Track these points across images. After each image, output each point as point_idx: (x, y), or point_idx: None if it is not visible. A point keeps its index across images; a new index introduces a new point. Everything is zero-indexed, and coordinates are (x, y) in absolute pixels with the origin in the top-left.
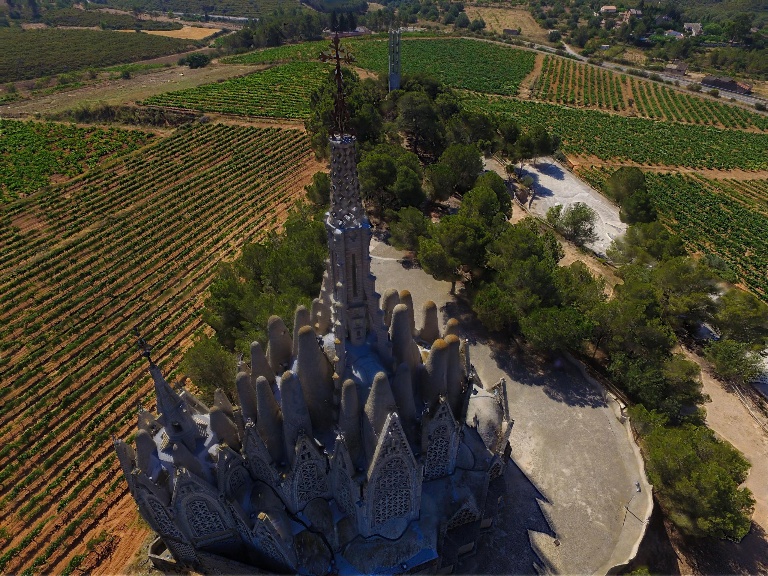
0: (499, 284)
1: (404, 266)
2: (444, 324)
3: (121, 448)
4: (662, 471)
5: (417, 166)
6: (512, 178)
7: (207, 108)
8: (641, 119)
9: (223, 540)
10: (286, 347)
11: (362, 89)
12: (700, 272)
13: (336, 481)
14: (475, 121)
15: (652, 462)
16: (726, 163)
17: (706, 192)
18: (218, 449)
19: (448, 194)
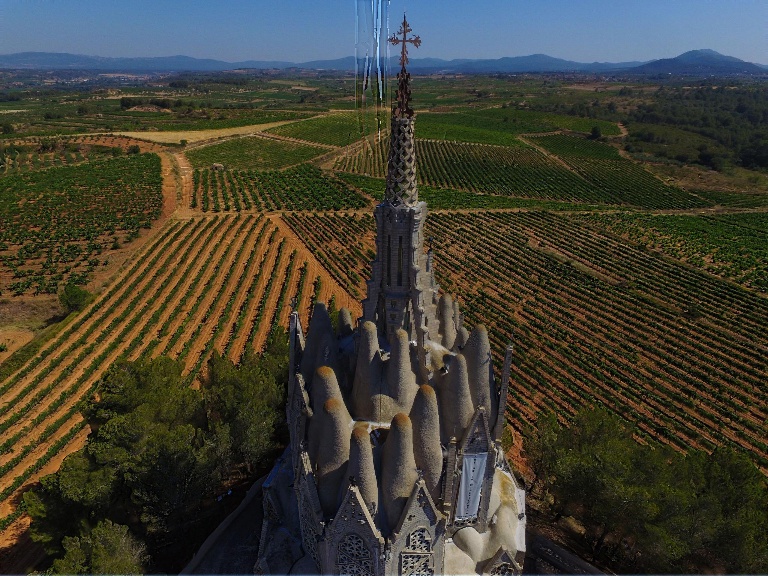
0: None
1: None
2: None
3: None
4: None
5: None
6: None
7: None
8: None
9: None
10: None
11: None
12: None
13: None
14: None
15: None
16: None
17: None
18: None
19: None
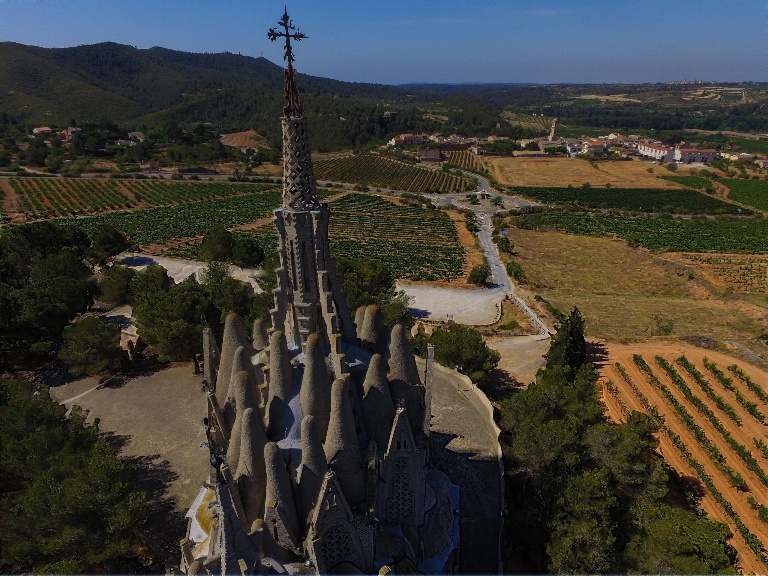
0: None
1: (113, 387)
2: None
3: None
4: (451, 358)
5: None
6: None
7: None
8: (159, 208)
9: None
10: (258, 407)
11: None
12: (340, 261)
13: (386, 489)
14: (42, 231)
15: (441, 360)
16: (248, 218)
17: (258, 237)
18: (312, 544)
19: (83, 305)
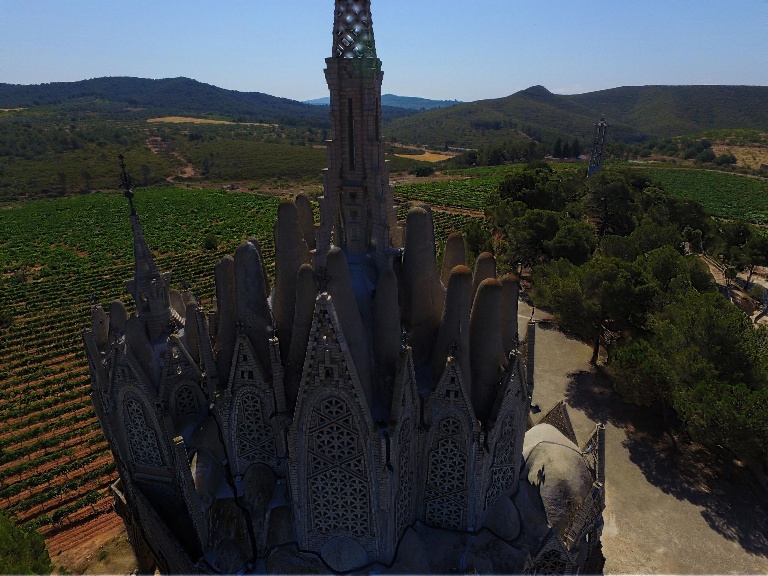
0: (657, 349)
1: (540, 326)
2: (567, 391)
3: (97, 315)
4: None
5: (591, 237)
6: (732, 285)
7: (413, 197)
8: None
9: (162, 484)
10: None
11: (555, 177)
12: None
13: None
14: (683, 207)
15: None
16: None
17: None
18: None
19: None
